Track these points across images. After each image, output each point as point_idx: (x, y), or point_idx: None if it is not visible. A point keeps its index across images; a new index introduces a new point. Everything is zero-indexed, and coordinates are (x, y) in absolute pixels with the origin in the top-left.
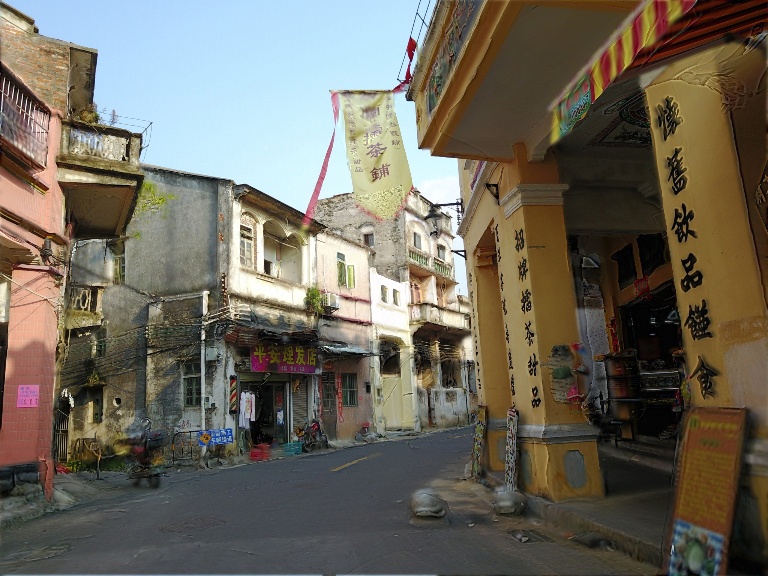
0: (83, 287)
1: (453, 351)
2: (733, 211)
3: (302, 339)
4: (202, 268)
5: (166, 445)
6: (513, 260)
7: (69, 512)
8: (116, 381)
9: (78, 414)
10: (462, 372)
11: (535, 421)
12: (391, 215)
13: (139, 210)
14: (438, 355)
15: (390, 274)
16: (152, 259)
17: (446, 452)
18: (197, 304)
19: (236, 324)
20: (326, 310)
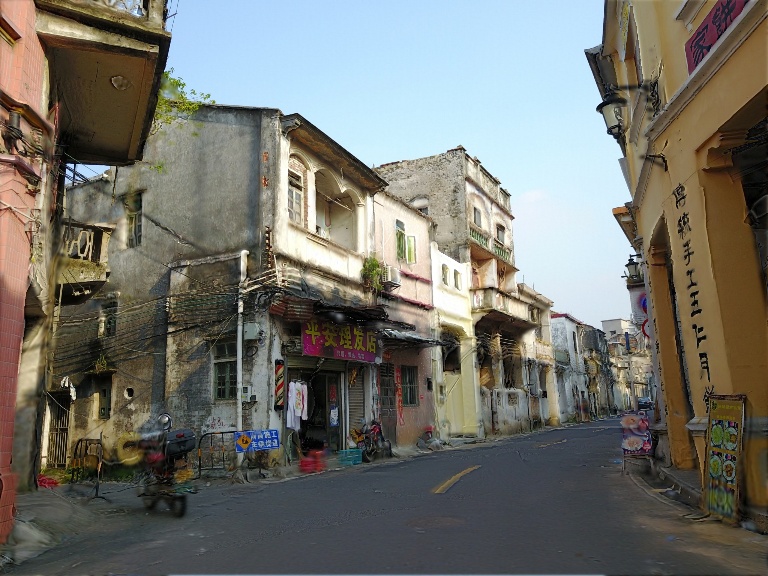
0: (82, 227)
1: (515, 346)
2: None
3: (367, 315)
4: (239, 222)
5: (190, 449)
6: None
7: (29, 570)
8: (128, 367)
9: (81, 408)
10: (523, 371)
11: None
12: (449, 186)
13: (161, 115)
14: (500, 350)
15: (448, 254)
16: (175, 214)
17: (570, 466)
18: (233, 267)
19: (284, 292)
20: (386, 286)
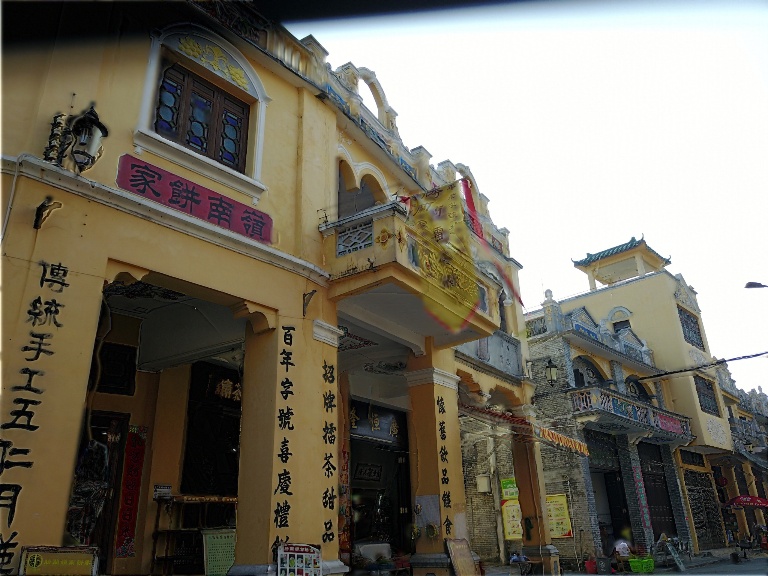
0: None
1: None
2: (459, 461)
3: None
4: None
5: None
6: (318, 384)
7: None
8: None
9: None
10: None
11: (327, 556)
12: None
13: None
14: None
15: None
16: None
17: None
18: None
19: None
20: None
